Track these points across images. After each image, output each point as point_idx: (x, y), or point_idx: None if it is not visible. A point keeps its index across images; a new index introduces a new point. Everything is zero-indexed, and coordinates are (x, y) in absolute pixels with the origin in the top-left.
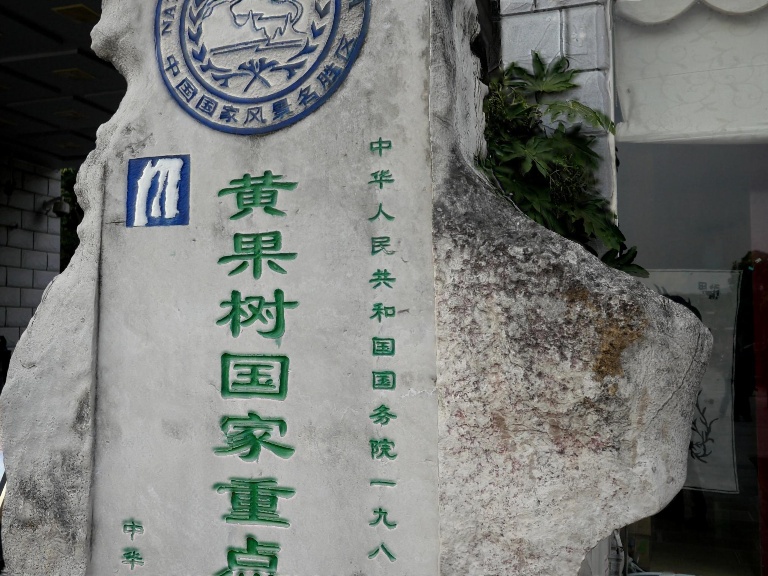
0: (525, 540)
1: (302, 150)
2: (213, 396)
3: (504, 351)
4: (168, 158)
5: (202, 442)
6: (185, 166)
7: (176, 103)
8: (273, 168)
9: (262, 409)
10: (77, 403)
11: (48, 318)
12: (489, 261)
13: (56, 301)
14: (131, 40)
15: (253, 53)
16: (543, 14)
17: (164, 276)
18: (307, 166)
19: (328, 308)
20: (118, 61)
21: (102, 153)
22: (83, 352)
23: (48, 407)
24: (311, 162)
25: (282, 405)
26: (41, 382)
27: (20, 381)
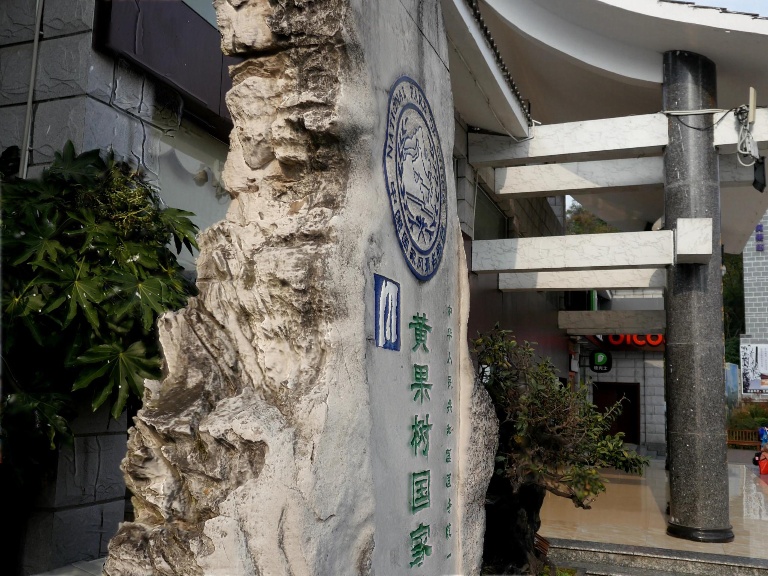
0: (477, 568)
1: (433, 302)
2: (409, 514)
3: (482, 453)
4: (392, 282)
5: (402, 560)
6: (398, 294)
7: (395, 230)
8: (426, 312)
9: (423, 517)
10: (360, 551)
11: (334, 451)
12: (484, 398)
13: (340, 428)
14: (371, 145)
15: (420, 210)
16: (133, 119)
17: (391, 400)
18: (434, 316)
19: (439, 429)
20: (350, 154)
21: (355, 256)
22: (368, 488)
23: (342, 565)
24: (435, 313)
25: (429, 511)
26: (336, 535)
27: (321, 540)
